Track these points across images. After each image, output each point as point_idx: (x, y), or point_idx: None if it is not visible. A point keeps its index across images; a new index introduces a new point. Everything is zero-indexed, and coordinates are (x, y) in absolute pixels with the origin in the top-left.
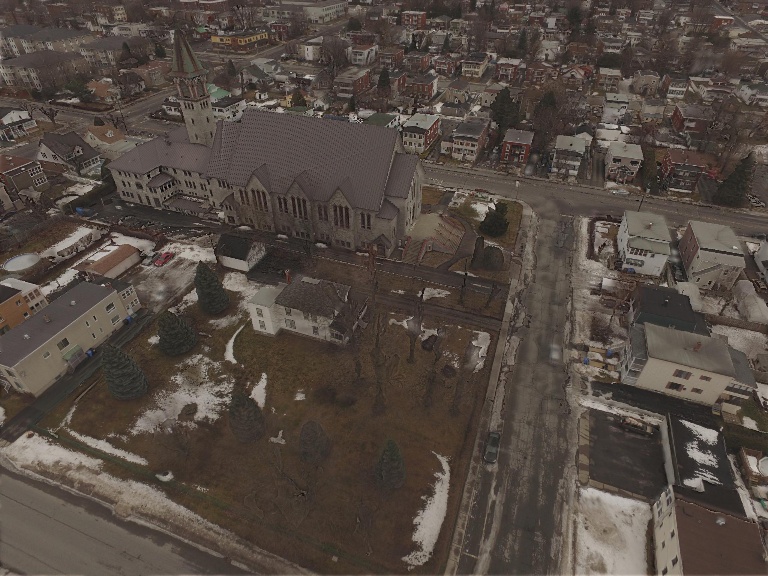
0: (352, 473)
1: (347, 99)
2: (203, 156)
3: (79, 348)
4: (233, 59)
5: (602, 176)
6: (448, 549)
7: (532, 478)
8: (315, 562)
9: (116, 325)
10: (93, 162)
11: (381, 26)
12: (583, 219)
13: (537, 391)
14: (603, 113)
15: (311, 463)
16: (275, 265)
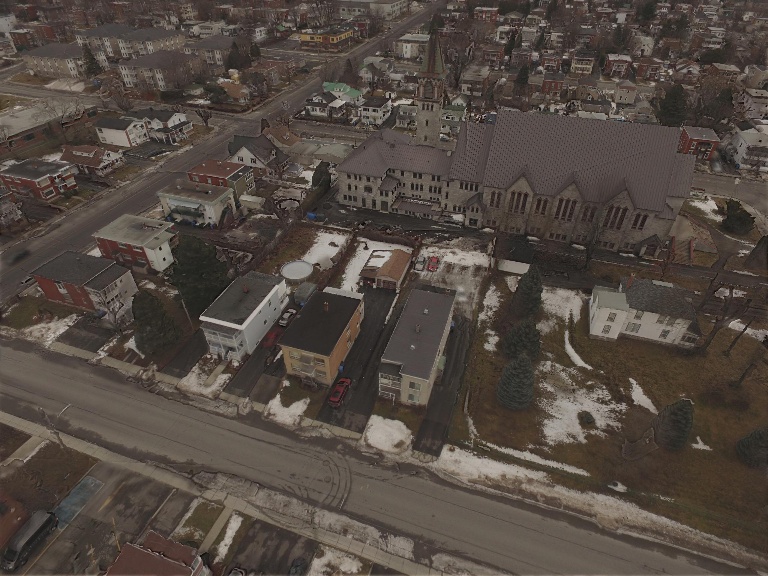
0: None
1: (477, 97)
2: (435, 158)
3: (445, 358)
4: (329, 58)
5: None
6: None
7: None
8: None
9: (448, 333)
10: (284, 165)
11: (472, 23)
12: None
13: None
14: (746, 109)
15: (764, 469)
16: (549, 268)
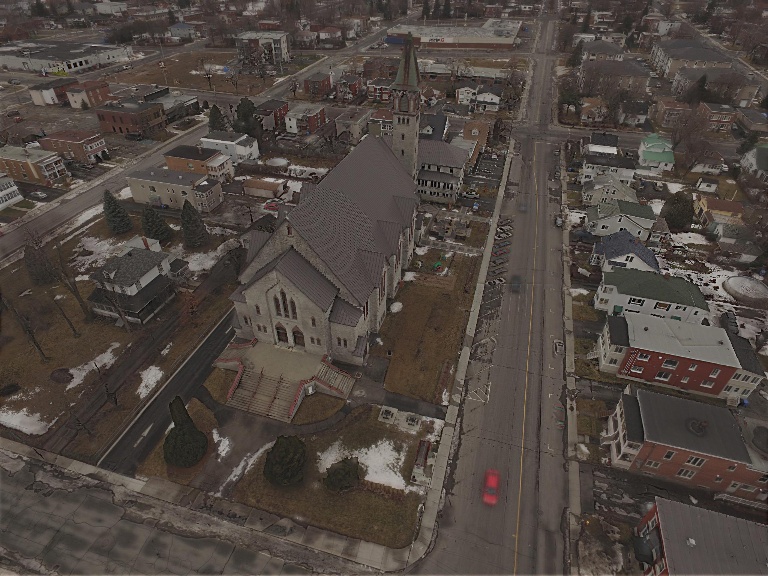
0: None
1: None
2: None
3: (157, 198)
4: None
5: None
6: None
7: None
8: None
9: None
10: None
11: None
12: None
13: None
14: None
15: None
16: None
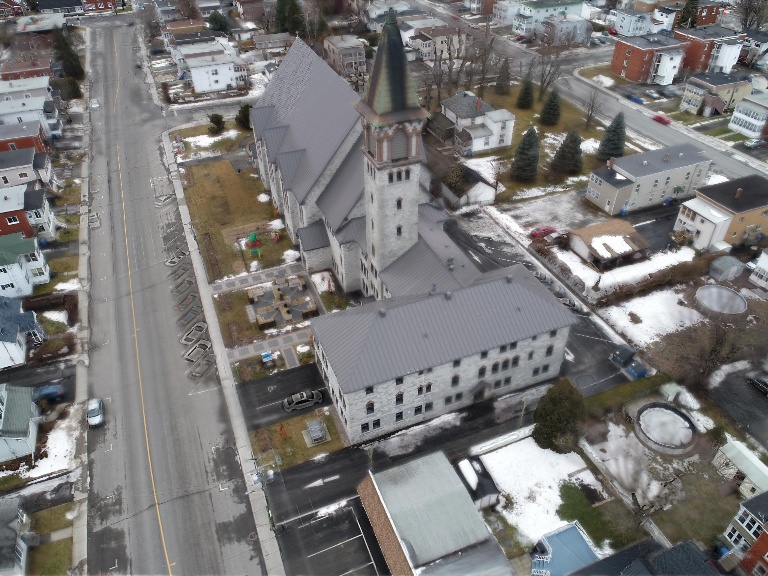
0: None
1: None
2: (420, 222)
3: None
4: None
5: None
6: None
7: None
8: None
9: None
10: None
11: None
12: (176, 107)
13: None
14: None
15: None
16: None
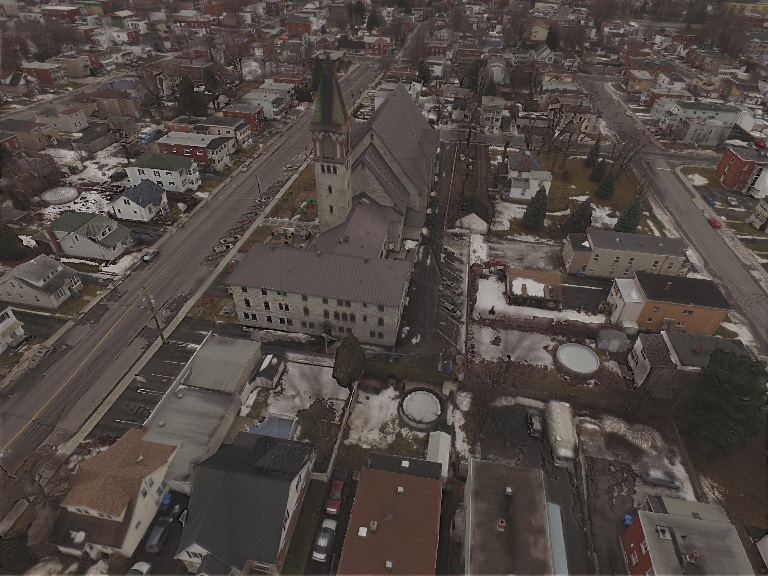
0: None
1: None
2: (369, 214)
3: None
4: None
5: (286, 108)
6: (603, 156)
7: None
8: None
9: None
10: None
11: None
12: None
13: None
14: None
15: None
16: None
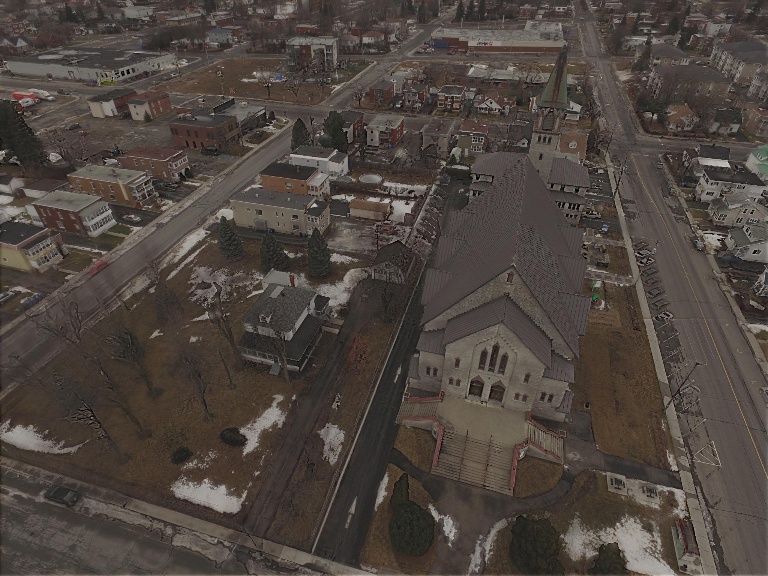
0: (99, 380)
1: None
2: None
3: (263, 221)
4: None
5: None
6: None
7: (6, 537)
8: (44, 369)
9: (295, 231)
10: None
11: None
12: None
13: (114, 569)
14: None
15: None
16: None
